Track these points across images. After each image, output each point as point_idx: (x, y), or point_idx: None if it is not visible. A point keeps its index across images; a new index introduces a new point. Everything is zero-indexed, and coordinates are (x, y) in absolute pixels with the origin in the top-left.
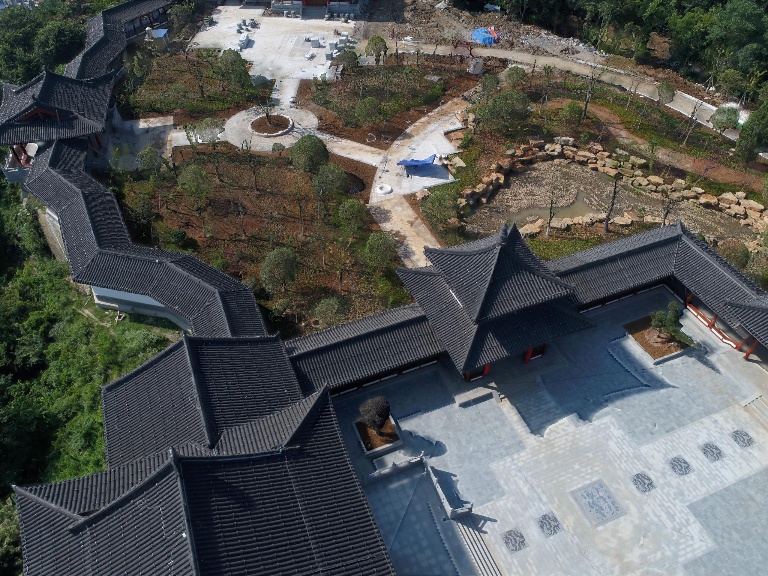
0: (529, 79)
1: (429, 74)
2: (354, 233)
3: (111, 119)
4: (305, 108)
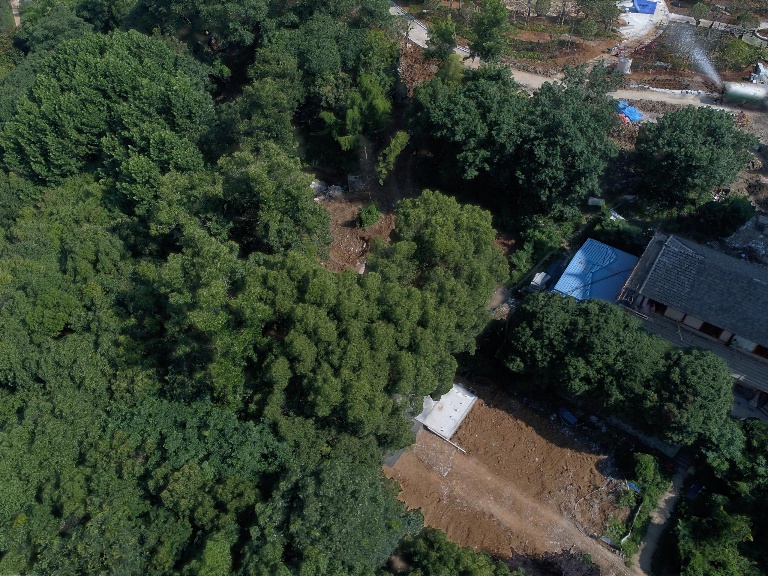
0: None
1: None
2: None
3: None
4: None
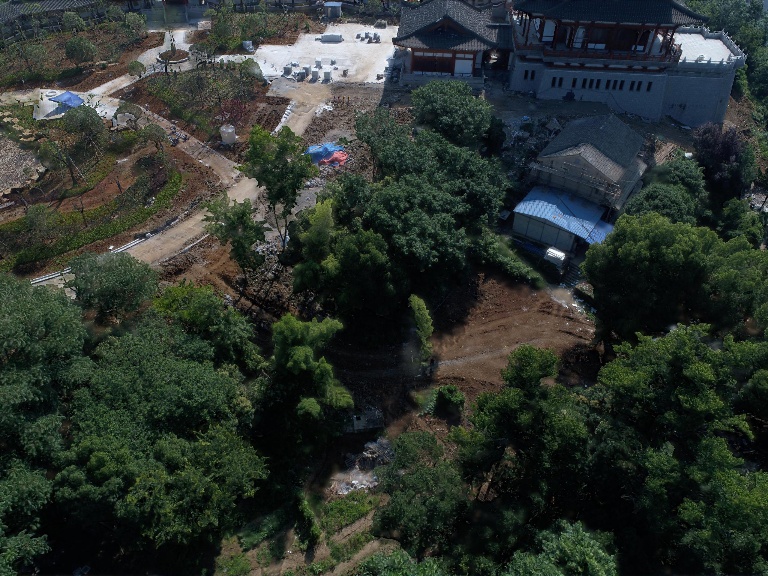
0: (200, 173)
1: None
2: (4, 80)
3: (191, 6)
4: None
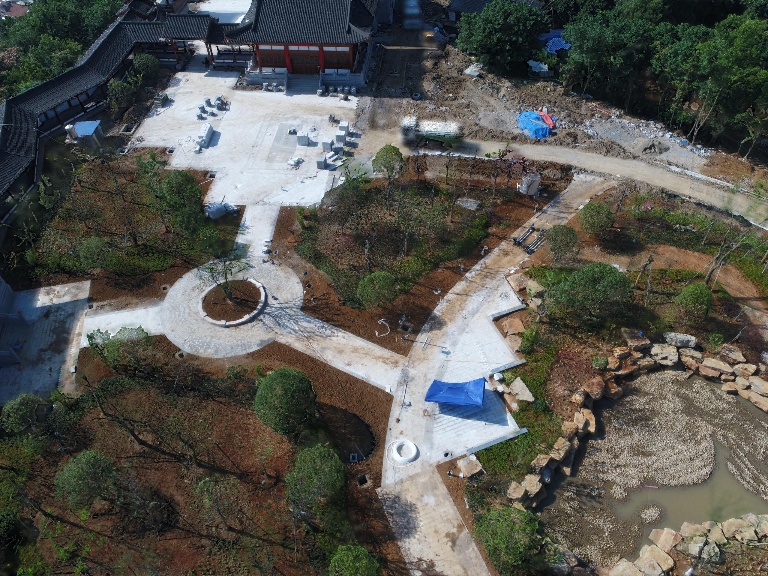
0: (607, 203)
1: (463, 196)
2: None
3: None
4: (285, 263)
